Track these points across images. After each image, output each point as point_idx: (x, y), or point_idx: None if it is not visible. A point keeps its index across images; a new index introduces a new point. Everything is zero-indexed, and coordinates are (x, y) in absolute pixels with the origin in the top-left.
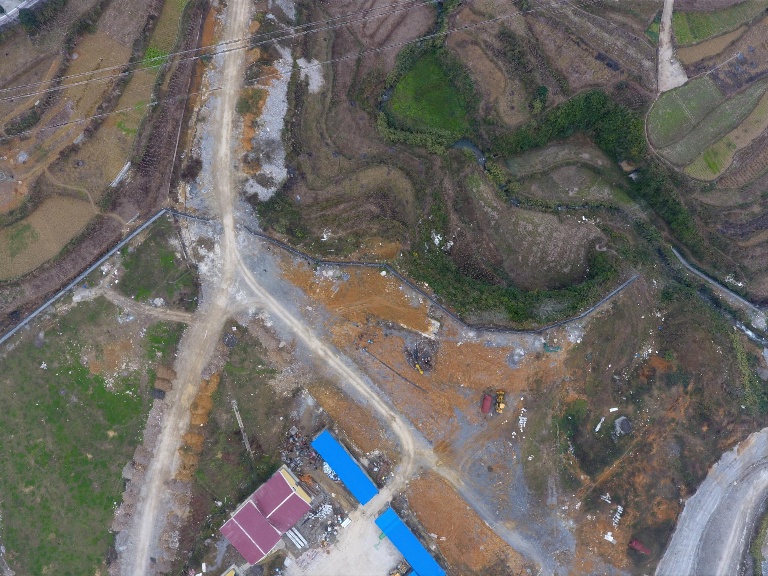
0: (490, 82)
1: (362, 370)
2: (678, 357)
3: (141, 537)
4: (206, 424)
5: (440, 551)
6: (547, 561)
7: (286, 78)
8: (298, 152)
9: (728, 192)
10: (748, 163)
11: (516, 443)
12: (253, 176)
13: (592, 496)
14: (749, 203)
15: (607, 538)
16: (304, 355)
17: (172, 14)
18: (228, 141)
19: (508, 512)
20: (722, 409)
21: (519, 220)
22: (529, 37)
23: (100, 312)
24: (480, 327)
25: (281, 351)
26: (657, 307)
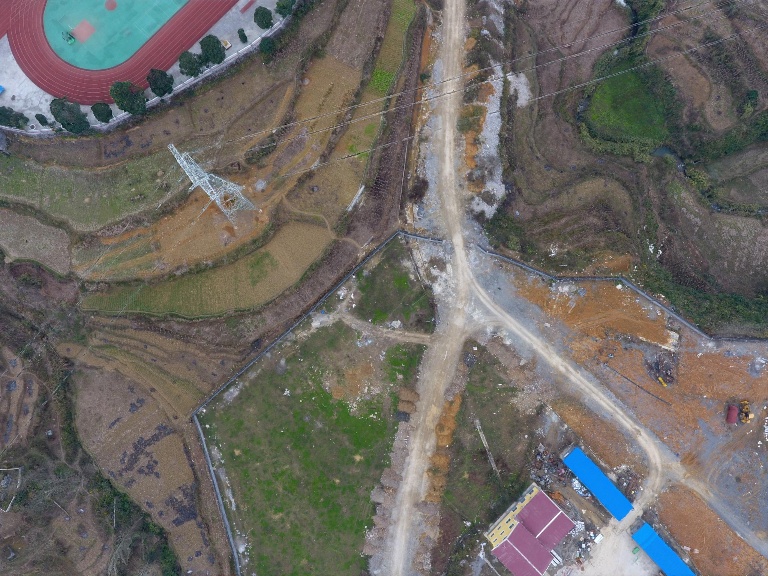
0: (693, 88)
1: (604, 385)
2: None
3: (394, 560)
4: (451, 445)
5: (693, 564)
6: None
7: (499, 93)
8: (513, 167)
9: None
10: None
11: (762, 452)
12: (478, 194)
13: None
14: None
15: None
16: (545, 372)
17: (396, 35)
18: (452, 160)
19: (759, 522)
20: None
21: (722, 225)
22: (737, 41)
23: (339, 337)
24: (719, 337)
25: (523, 369)
26: None
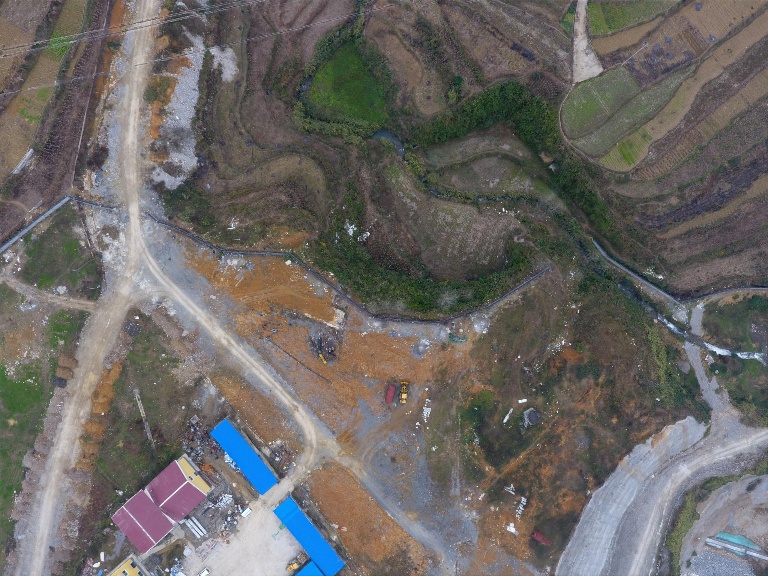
0: (408, 72)
1: (265, 359)
2: (590, 349)
3: (40, 526)
4: (108, 413)
5: (341, 541)
6: (449, 552)
7: (198, 66)
8: (209, 141)
9: (644, 184)
10: (664, 155)
11: (420, 434)
12: (160, 164)
13: (496, 487)
14: (665, 195)
15: (509, 529)
16: (207, 344)
17: (77, 0)
18: (135, 129)
19: (410, 503)
20: (633, 401)
21: (438, 211)
22: (445, 27)
23: (2, 300)
24: (385, 317)
25: (183, 340)
26: (573, 299)
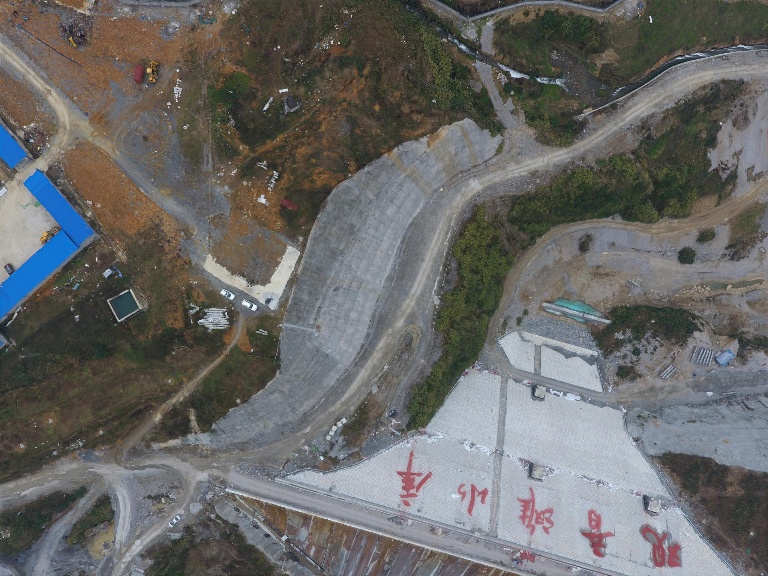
0: None
1: (18, 47)
2: (355, 43)
3: None
4: None
5: (96, 217)
6: (201, 224)
7: None
8: None
9: None
10: None
11: (171, 113)
12: None
13: (248, 163)
14: None
15: (260, 200)
16: None
17: None
18: None
19: (163, 179)
20: (399, 92)
21: None
22: None
23: None
24: (135, 2)
25: None
26: (346, 5)
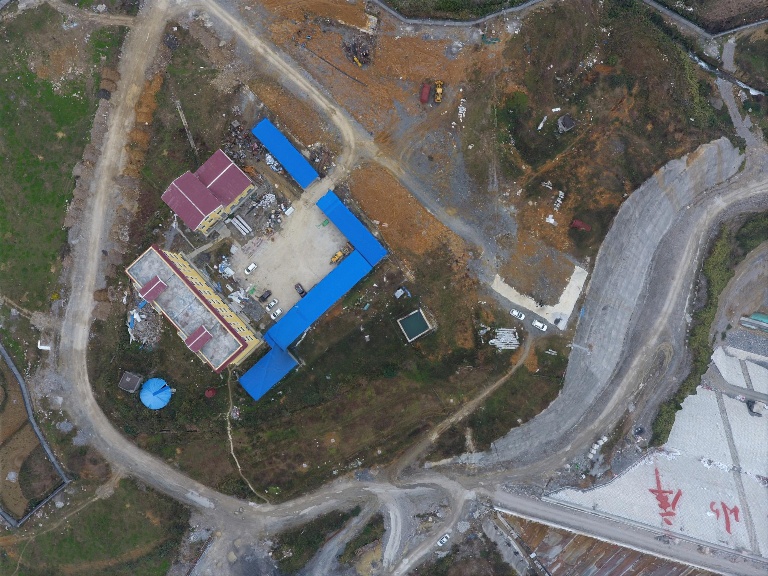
0: None
1: (301, 66)
2: (622, 62)
3: (92, 231)
4: (151, 123)
5: (383, 237)
6: (489, 244)
7: None
8: None
9: None
10: None
11: (456, 133)
12: None
13: (533, 183)
14: None
15: (548, 220)
16: (244, 53)
17: None
18: None
19: (449, 199)
20: (668, 111)
21: None
22: None
23: (45, 19)
24: (418, 21)
25: (221, 48)
26: (603, 23)
